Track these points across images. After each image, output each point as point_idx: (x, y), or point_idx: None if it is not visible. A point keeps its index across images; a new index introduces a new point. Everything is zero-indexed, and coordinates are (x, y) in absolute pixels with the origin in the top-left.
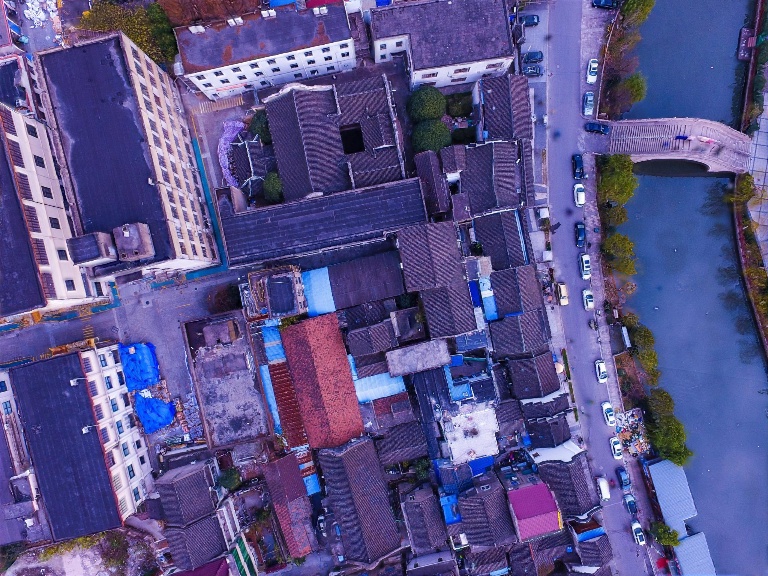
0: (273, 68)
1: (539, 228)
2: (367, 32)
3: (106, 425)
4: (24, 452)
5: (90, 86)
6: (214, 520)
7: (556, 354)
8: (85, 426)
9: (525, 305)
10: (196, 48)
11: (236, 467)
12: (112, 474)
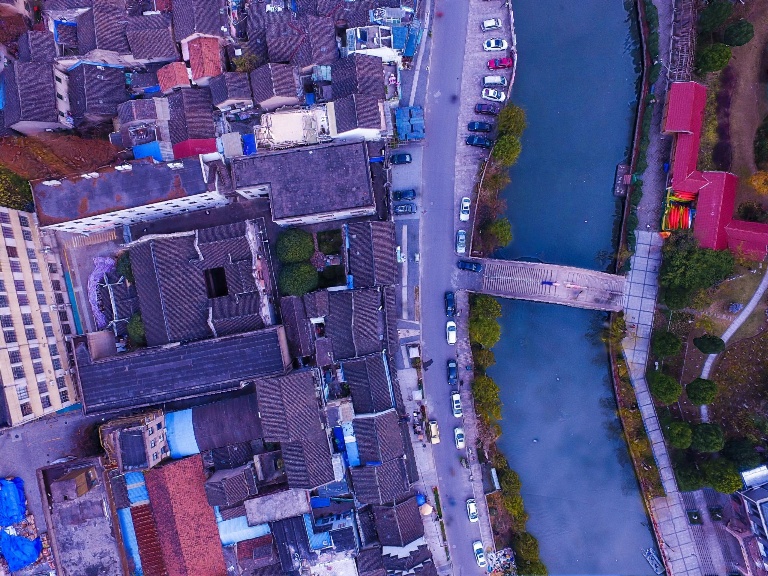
0: (136, 213)
1: None
2: (230, 178)
3: None
4: None
5: None
6: None
7: (428, 492)
8: None
9: (384, 455)
10: (52, 200)
11: None
12: None
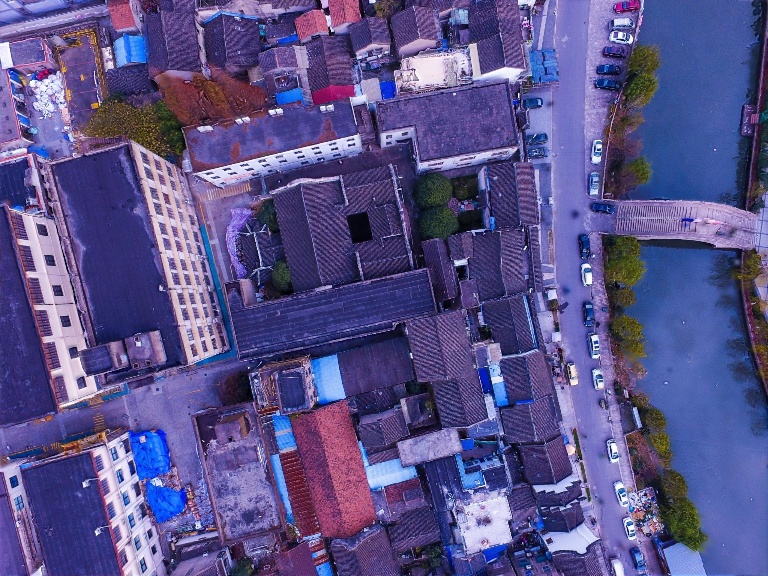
0: (280, 160)
1: (547, 309)
2: (373, 123)
3: (118, 522)
4: (36, 547)
5: (101, 194)
6: None
7: (567, 434)
8: (98, 527)
9: (536, 392)
10: (204, 146)
11: (248, 556)
12: (125, 574)
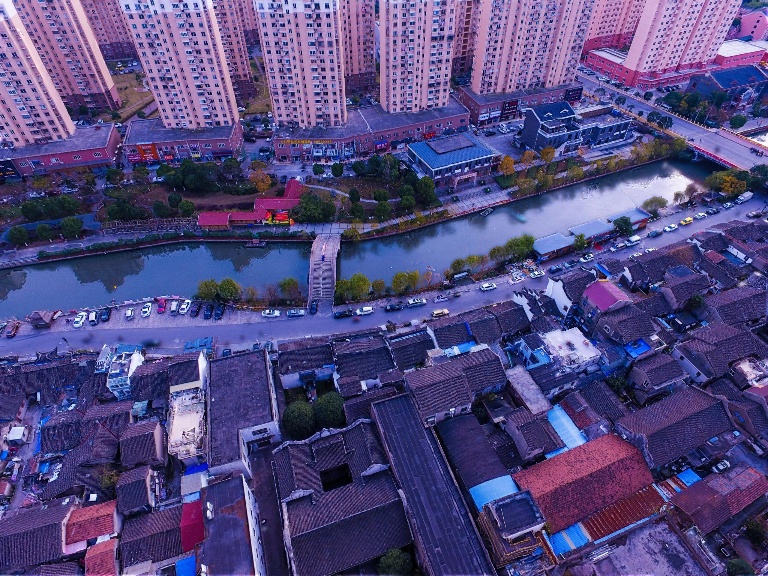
0: None
1: None
2: None
3: None
4: None
5: None
6: None
7: None
8: None
9: None
10: None
11: (723, 568)
12: None
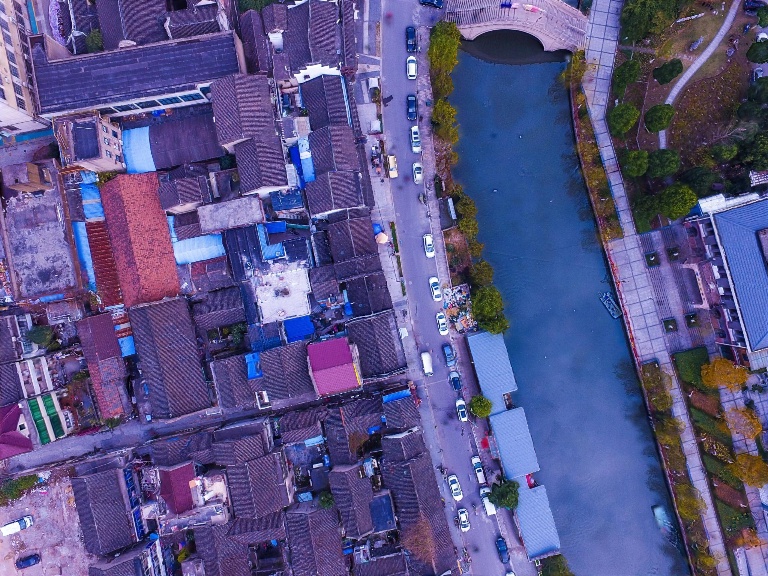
0: None
1: None
2: None
3: None
4: None
5: None
6: (12, 367)
7: (385, 227)
8: None
9: (339, 164)
10: None
11: (51, 326)
12: None
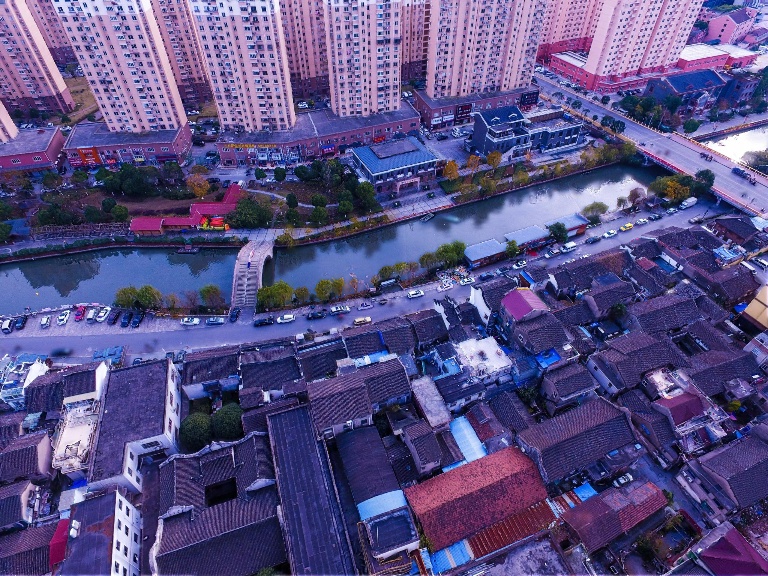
0: None
1: None
2: None
3: None
4: None
5: None
6: None
7: None
8: None
9: None
10: None
11: None
12: None
